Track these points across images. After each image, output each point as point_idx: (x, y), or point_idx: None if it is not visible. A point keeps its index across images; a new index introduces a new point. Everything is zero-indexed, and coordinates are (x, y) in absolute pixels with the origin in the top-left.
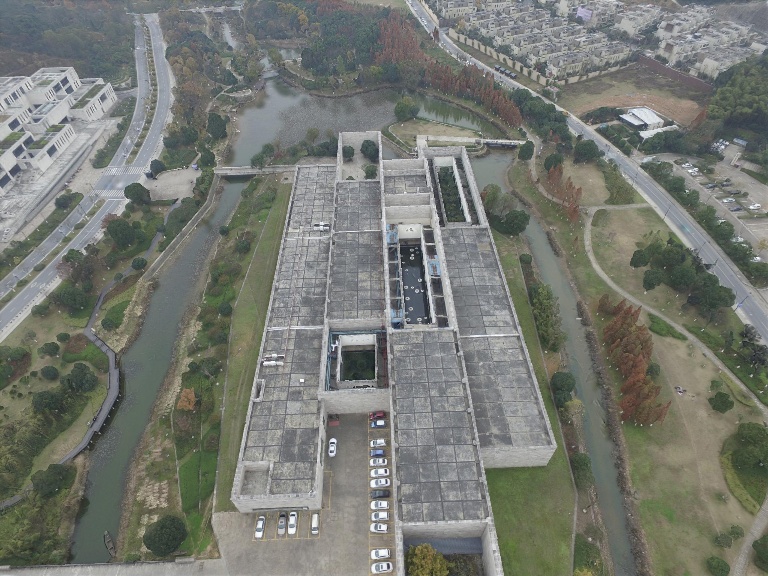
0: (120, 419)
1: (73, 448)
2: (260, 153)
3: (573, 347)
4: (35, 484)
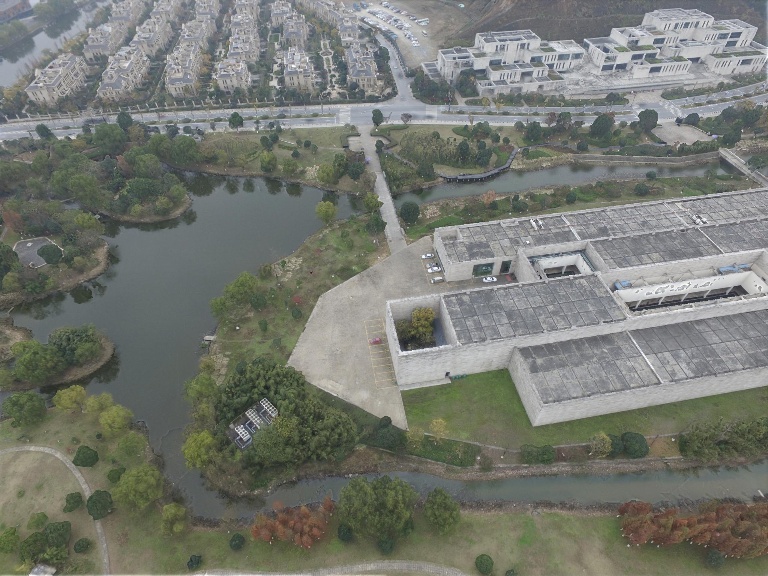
0: (469, 185)
1: (445, 174)
2: (767, 158)
3: (705, 481)
4: (421, 163)
